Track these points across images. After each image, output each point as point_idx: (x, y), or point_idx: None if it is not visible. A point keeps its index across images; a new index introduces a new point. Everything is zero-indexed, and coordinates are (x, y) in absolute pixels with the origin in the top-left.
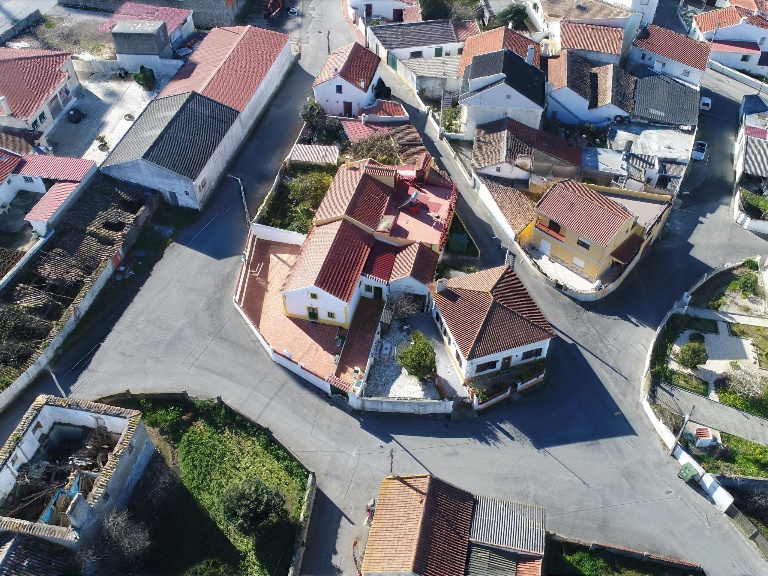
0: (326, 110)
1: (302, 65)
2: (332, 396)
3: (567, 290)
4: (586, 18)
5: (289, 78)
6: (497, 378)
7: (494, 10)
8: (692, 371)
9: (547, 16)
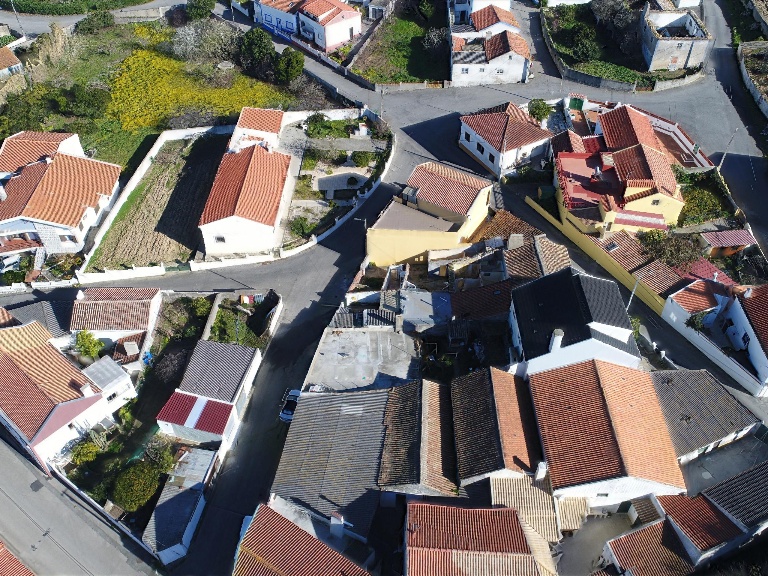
0: None
1: None
2: None
3: None
4: None
5: None
6: None
7: None
8: None
9: None
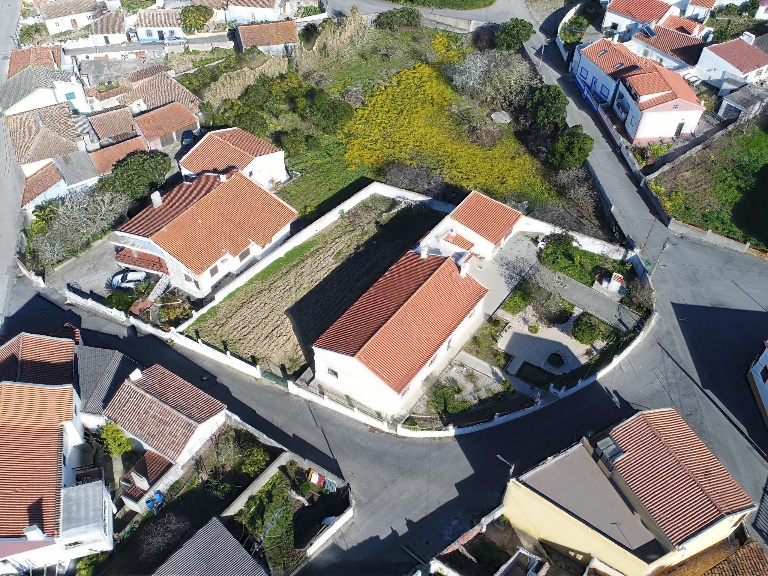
0: None
1: None
2: None
3: None
4: None
5: None
6: None
7: None
8: None
9: None
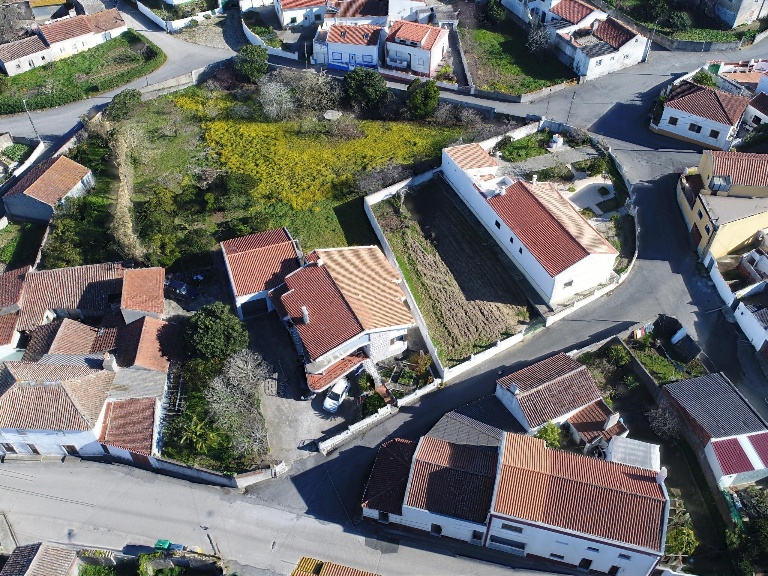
0: None
1: None
2: None
3: None
4: None
5: None
6: None
7: None
8: None
9: None
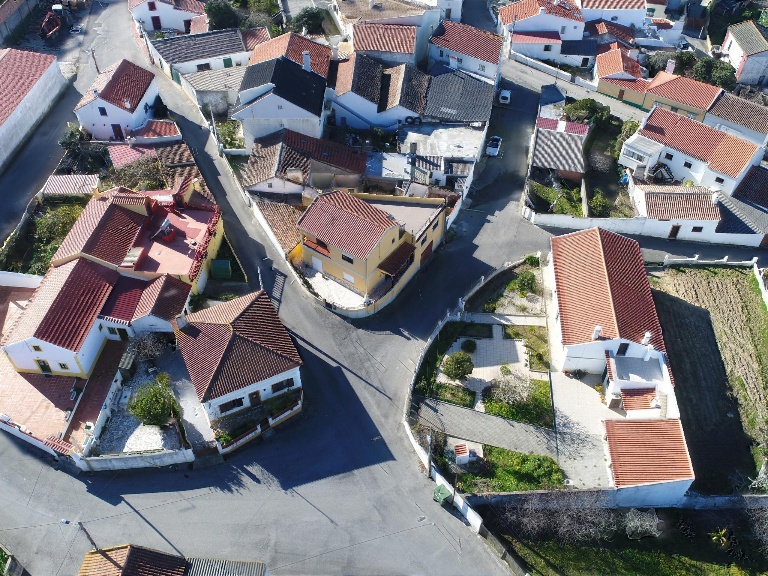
0: (95, 135)
1: (77, 87)
2: (59, 459)
3: (336, 309)
4: (381, 18)
5: (60, 102)
6: (248, 415)
7: (293, 15)
8: (460, 382)
9: (345, 18)
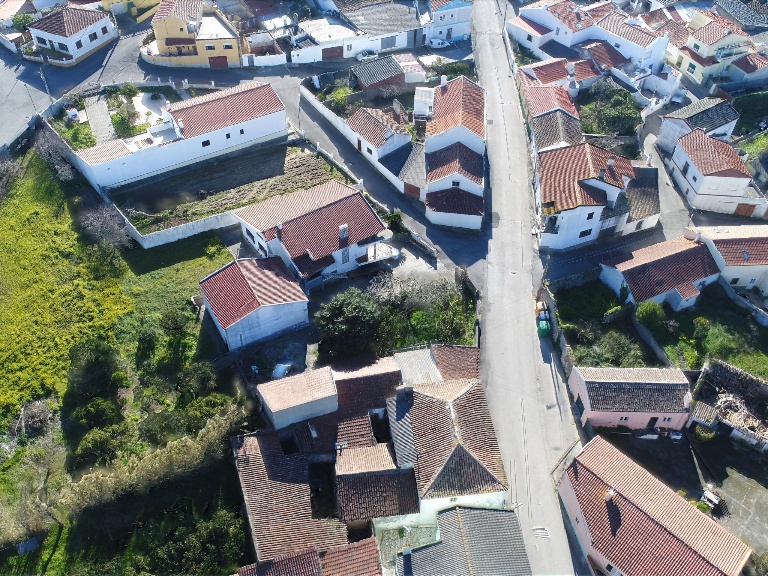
0: None
1: None
2: None
3: None
4: None
5: None
6: (48, 53)
7: None
8: (127, 102)
9: None
